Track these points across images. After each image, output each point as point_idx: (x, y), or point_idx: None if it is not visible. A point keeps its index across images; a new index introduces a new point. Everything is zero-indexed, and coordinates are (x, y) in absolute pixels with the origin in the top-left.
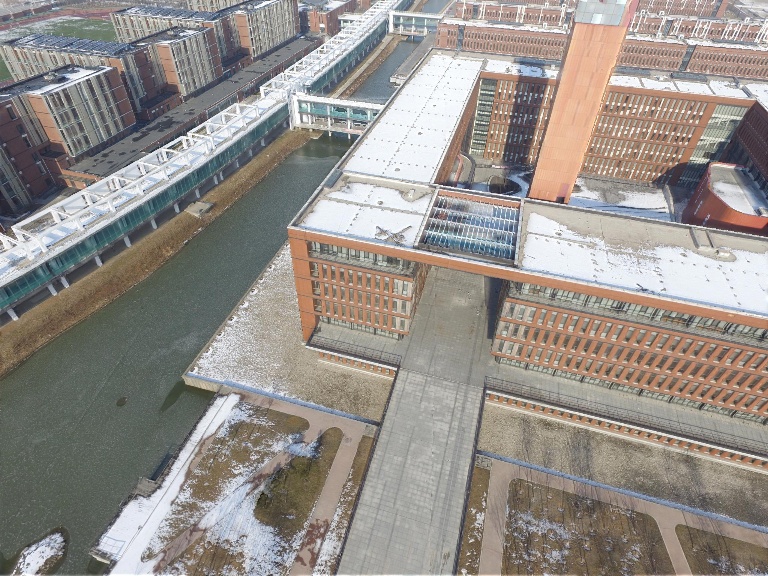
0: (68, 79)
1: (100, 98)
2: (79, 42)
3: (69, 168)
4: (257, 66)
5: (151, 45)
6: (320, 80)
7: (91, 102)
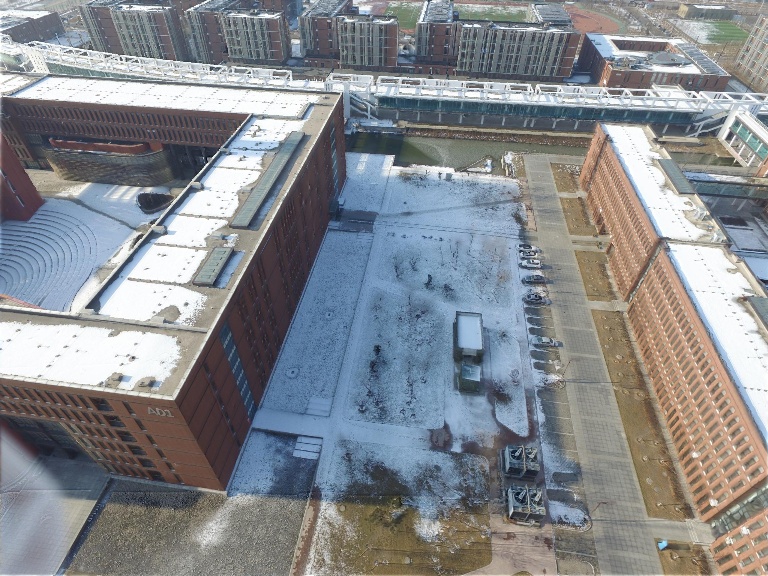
0: (256, 15)
1: (258, 32)
2: (329, 4)
3: (228, 62)
4: (446, 78)
5: (336, 18)
6: (402, 101)
7: (250, 32)
